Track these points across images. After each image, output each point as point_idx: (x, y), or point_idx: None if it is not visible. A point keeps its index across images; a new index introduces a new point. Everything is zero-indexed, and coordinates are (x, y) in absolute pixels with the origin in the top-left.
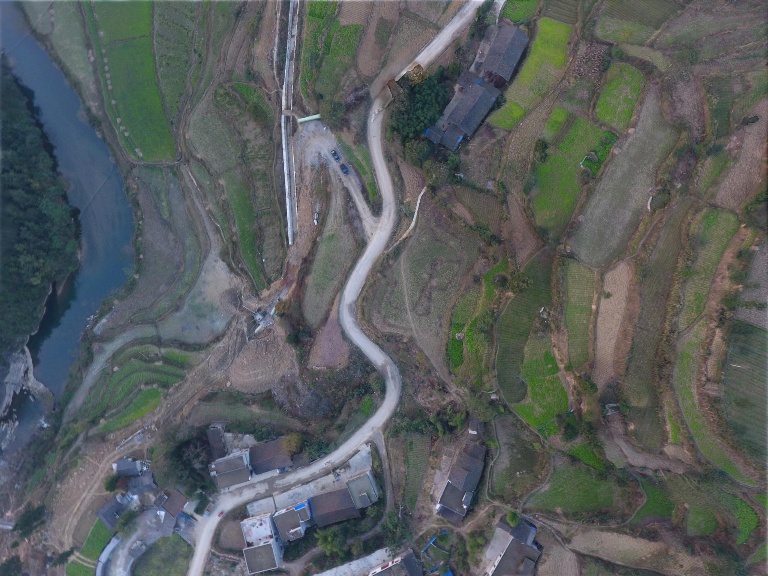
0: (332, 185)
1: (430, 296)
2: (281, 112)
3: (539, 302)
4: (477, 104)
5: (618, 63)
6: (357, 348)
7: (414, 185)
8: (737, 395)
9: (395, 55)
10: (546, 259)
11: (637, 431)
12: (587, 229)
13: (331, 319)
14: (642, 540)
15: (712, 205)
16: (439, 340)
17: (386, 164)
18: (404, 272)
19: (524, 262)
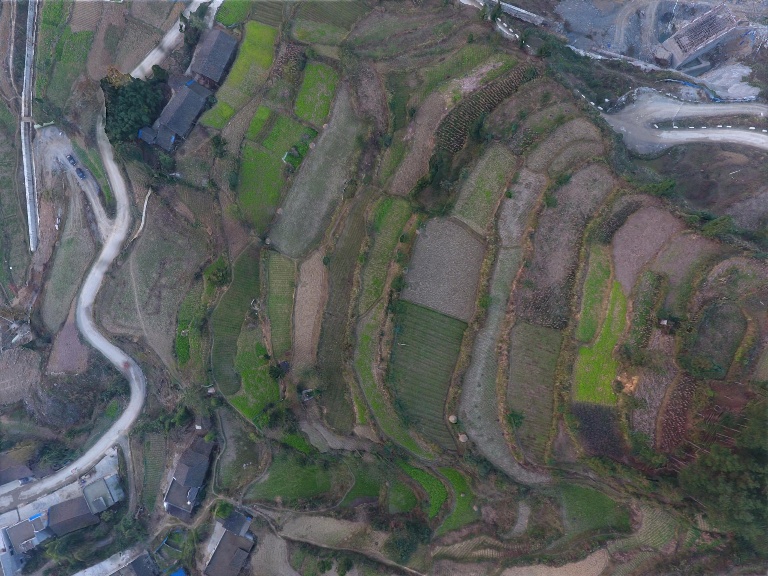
0: (70, 189)
1: (160, 295)
2: (21, 119)
3: (250, 295)
4: (184, 105)
5: (314, 63)
6: (96, 351)
7: (141, 186)
8: (405, 372)
9: (122, 60)
10: (255, 252)
11: (328, 414)
12: (286, 221)
13: (68, 323)
14: (345, 521)
15: (388, 193)
16: (170, 338)
17: (117, 167)
18: (133, 272)
19: (236, 256)
